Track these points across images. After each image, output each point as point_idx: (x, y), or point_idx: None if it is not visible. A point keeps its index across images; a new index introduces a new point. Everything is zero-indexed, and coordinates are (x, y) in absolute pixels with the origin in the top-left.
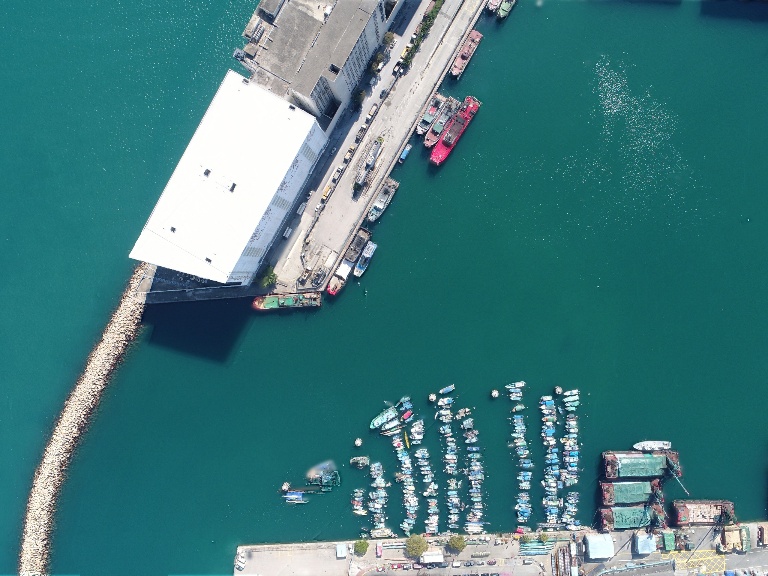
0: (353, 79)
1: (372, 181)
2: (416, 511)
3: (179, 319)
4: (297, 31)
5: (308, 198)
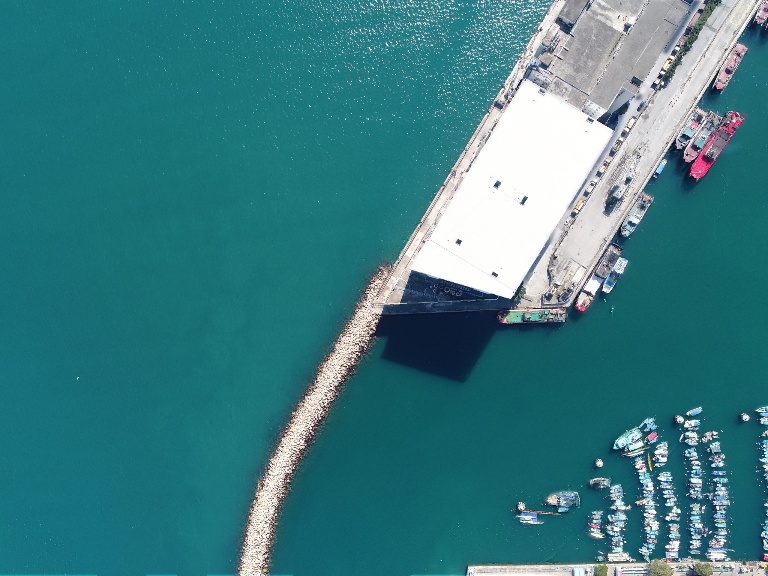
0: None
1: None
2: (656, 535)
3: (416, 331)
4: (594, 41)
5: None
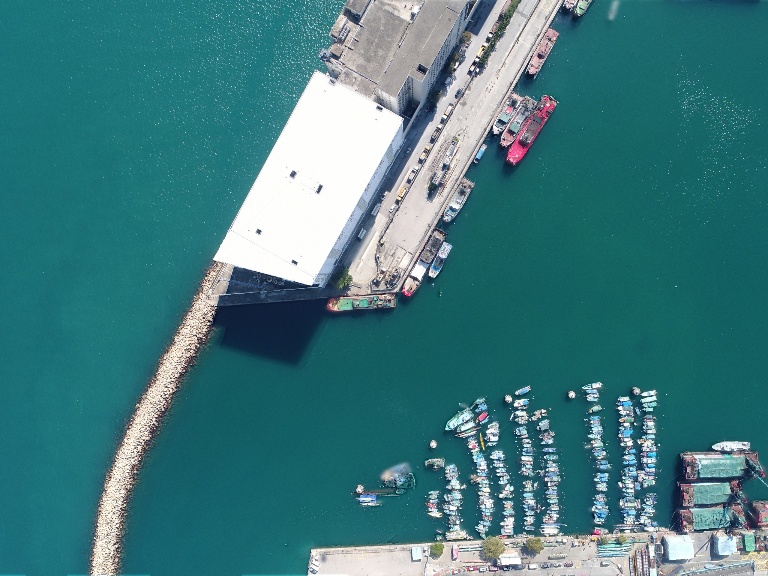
0: (433, 79)
1: (447, 181)
2: (491, 513)
3: (252, 321)
4: (383, 31)
5: (382, 199)
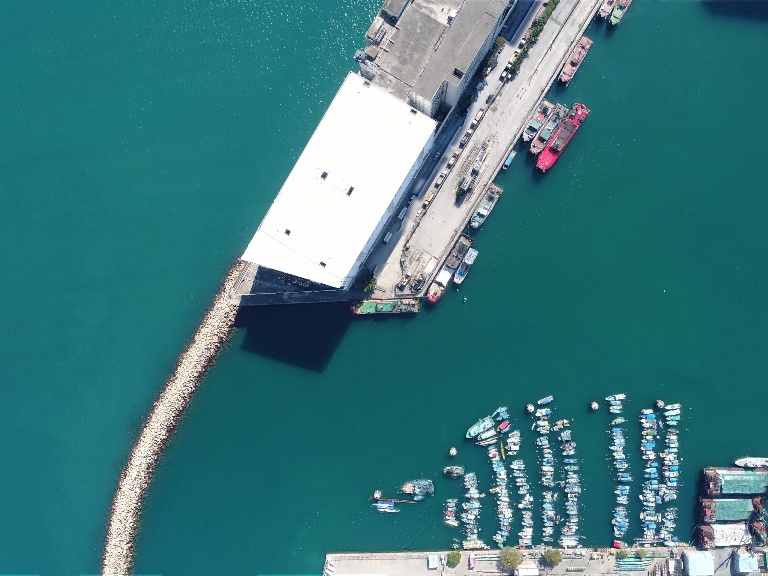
0: (465, 83)
1: (475, 187)
2: (510, 523)
3: (273, 322)
4: (419, 34)
5: (409, 203)
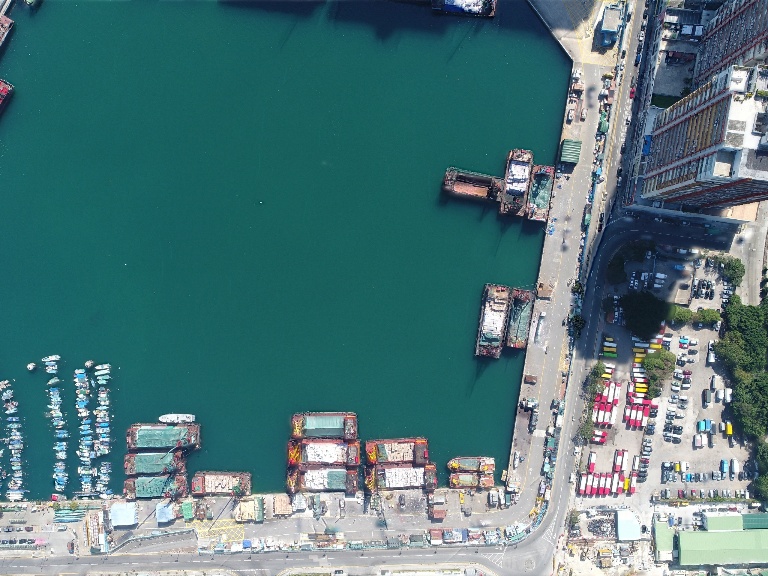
0: None
1: None
2: None
3: None
4: None
5: None
